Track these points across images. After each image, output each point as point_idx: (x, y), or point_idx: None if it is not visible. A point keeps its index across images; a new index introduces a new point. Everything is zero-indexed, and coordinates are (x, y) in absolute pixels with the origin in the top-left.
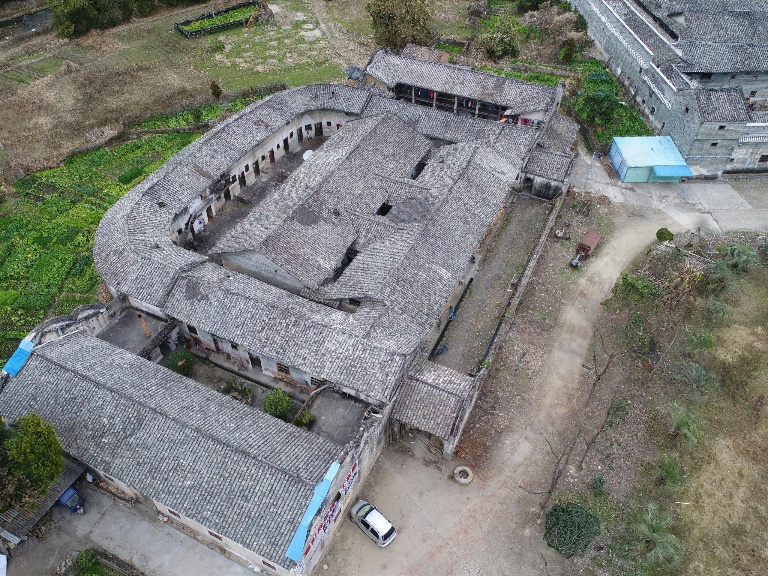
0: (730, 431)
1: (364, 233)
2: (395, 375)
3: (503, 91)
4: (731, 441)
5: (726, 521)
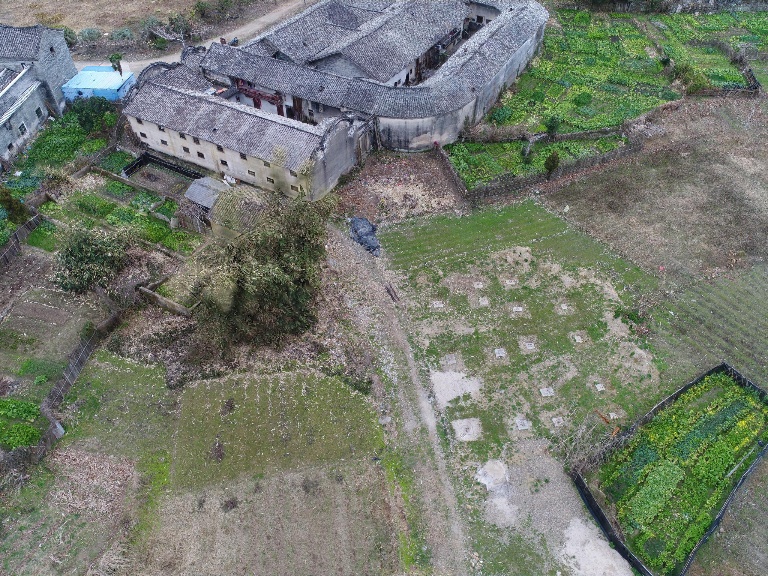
0: (217, 0)
1: None
2: None
3: None
4: None
5: None
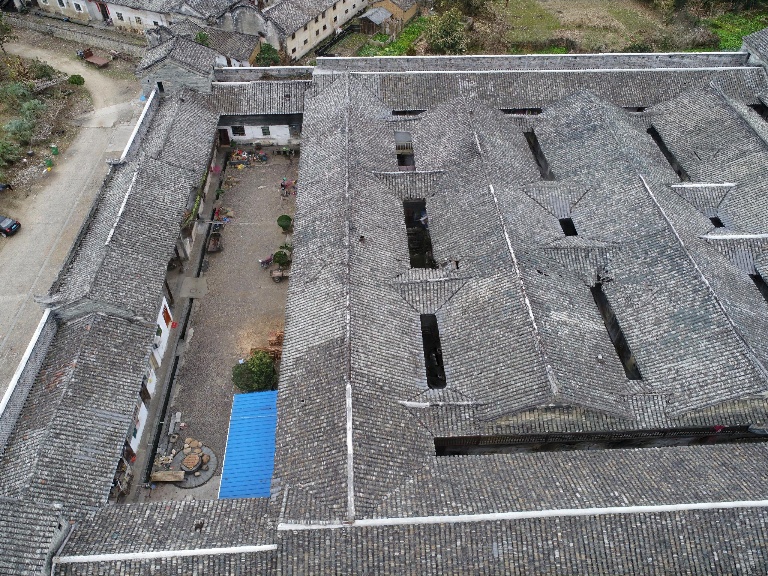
0: None
1: None
2: None
3: None
4: None
5: None
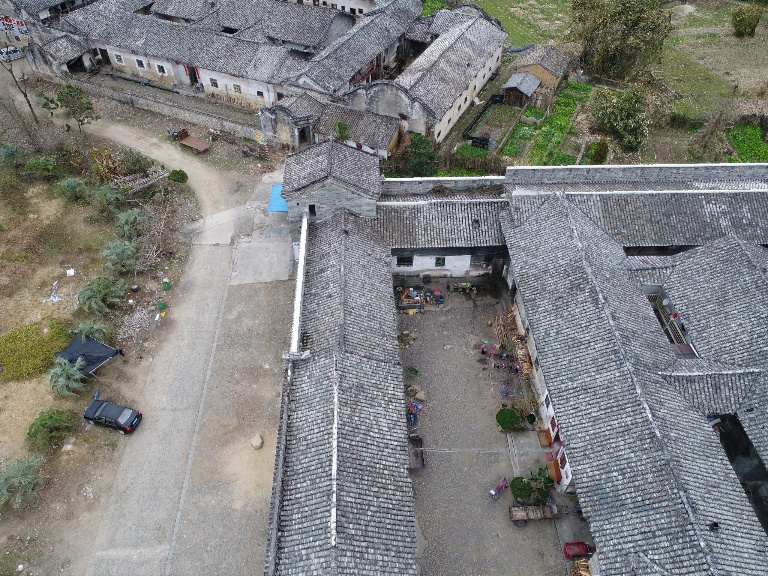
0: None
1: None
2: None
3: None
4: None
5: None
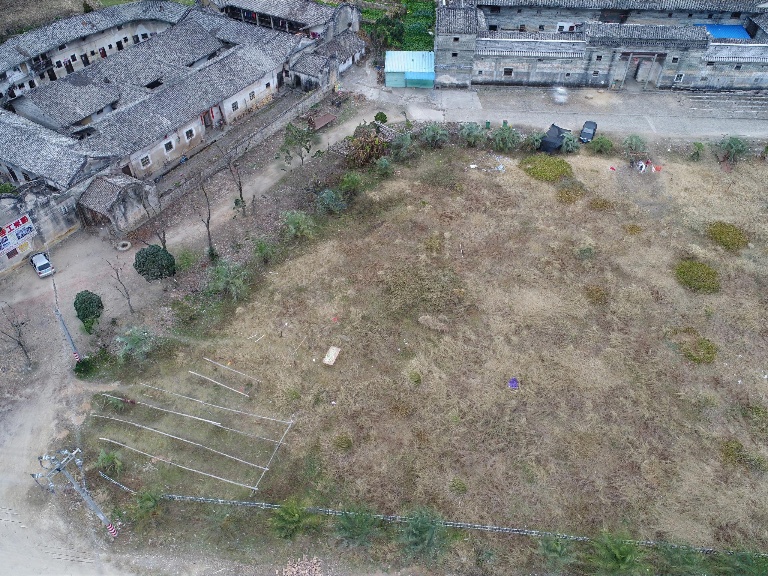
0: (343, 238)
1: (125, 96)
2: (77, 170)
3: (305, 12)
4: (338, 243)
5: (297, 284)
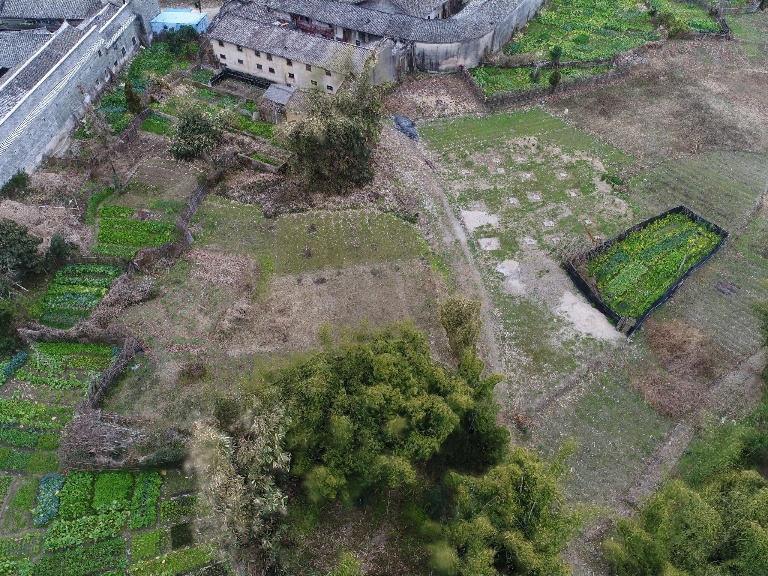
0: None
1: None
2: None
3: None
4: None
5: None
